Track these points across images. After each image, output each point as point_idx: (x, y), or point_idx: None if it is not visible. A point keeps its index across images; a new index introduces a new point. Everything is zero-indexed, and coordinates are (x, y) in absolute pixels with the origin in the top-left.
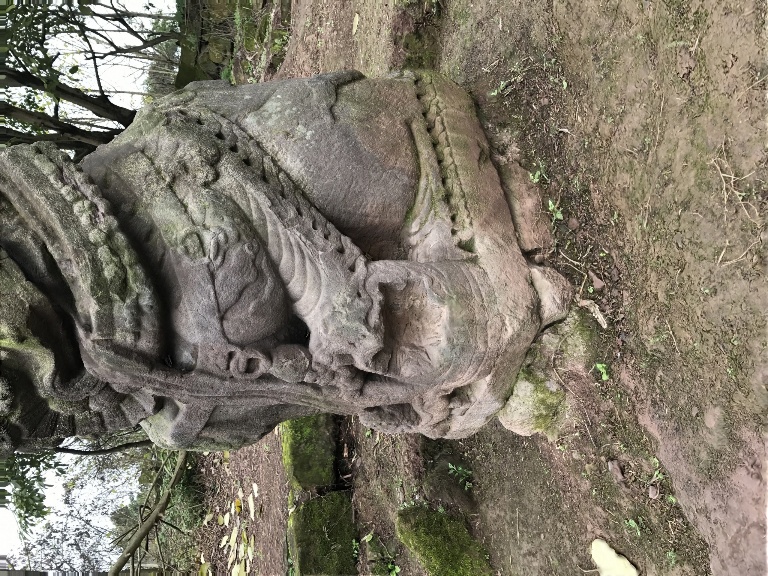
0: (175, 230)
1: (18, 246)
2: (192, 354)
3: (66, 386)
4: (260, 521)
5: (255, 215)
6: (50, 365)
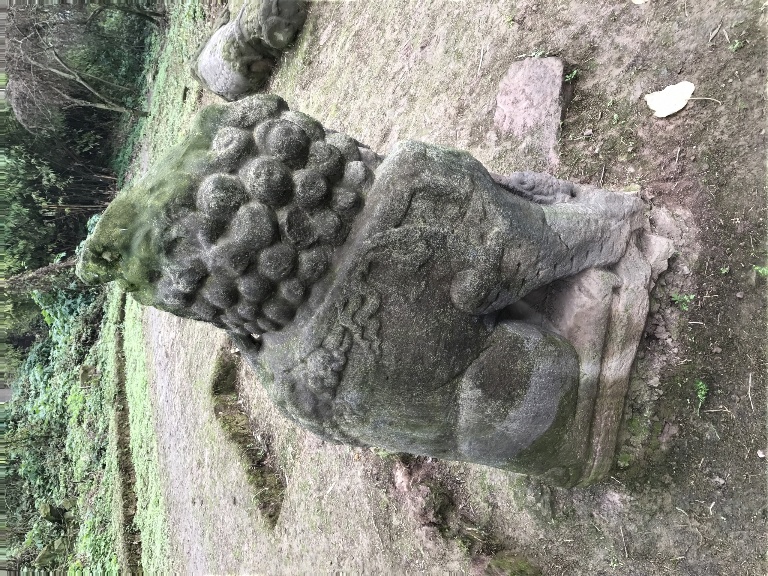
0: None
1: None
2: None
3: None
4: None
5: None
6: None
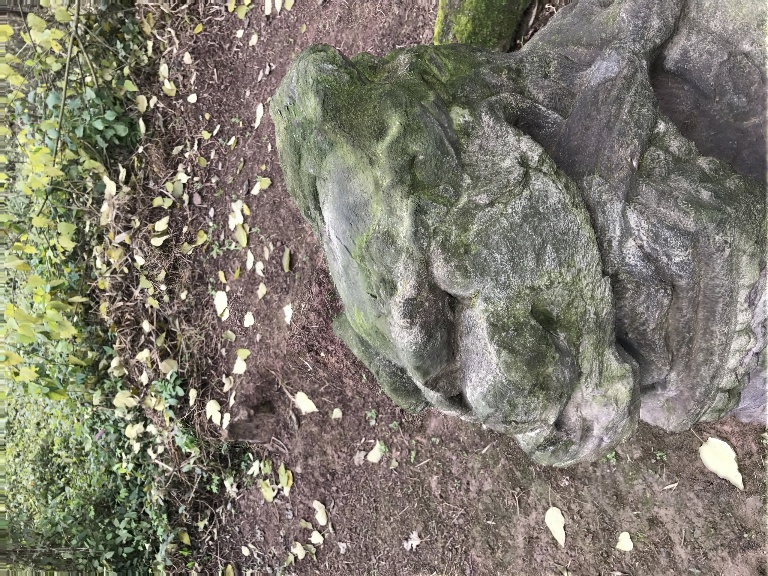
0: None
1: (639, 354)
2: None
3: None
4: (316, 1)
5: None
6: None
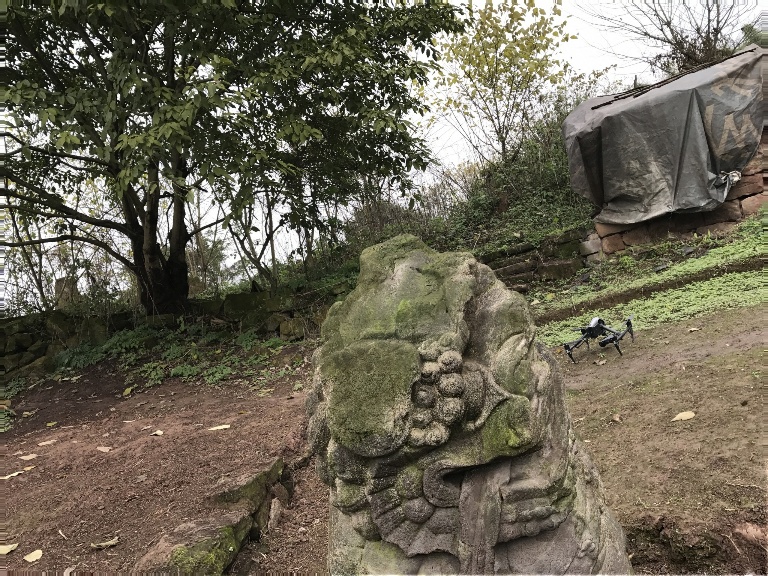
0: (577, 506)
1: None
2: (501, 570)
3: (441, 478)
4: None
5: (601, 558)
6: (465, 462)
